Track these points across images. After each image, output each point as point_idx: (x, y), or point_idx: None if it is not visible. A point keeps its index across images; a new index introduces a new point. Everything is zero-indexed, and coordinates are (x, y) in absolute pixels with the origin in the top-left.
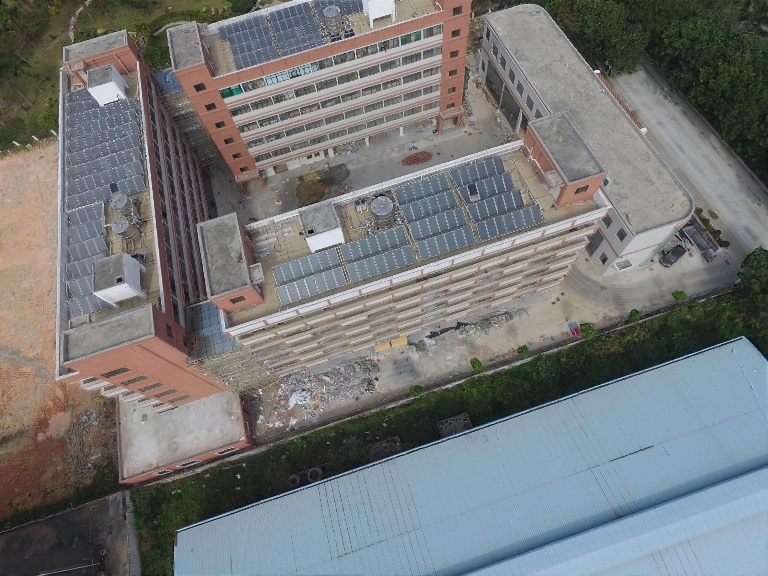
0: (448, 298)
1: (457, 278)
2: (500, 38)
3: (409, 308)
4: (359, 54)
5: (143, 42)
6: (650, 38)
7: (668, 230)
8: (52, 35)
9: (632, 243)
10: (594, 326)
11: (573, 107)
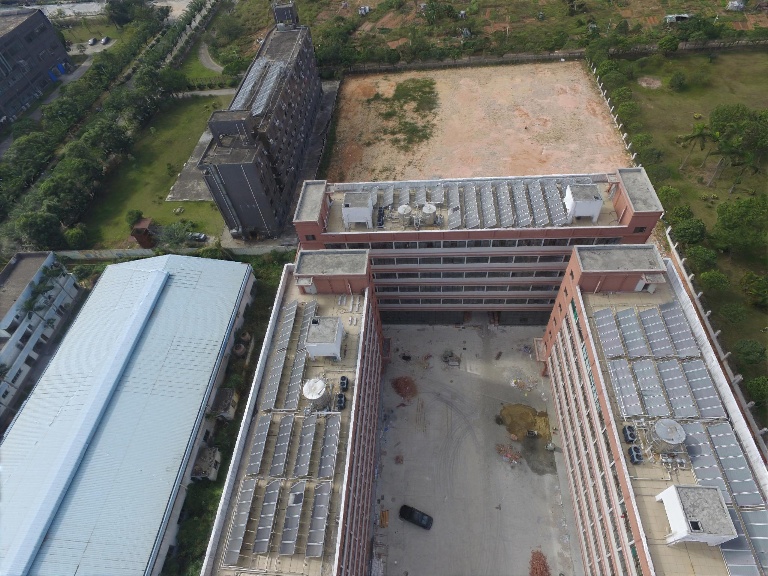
0: None
1: None
2: None
3: None
4: None
5: None
6: None
7: None
8: None
9: None
10: None
11: None
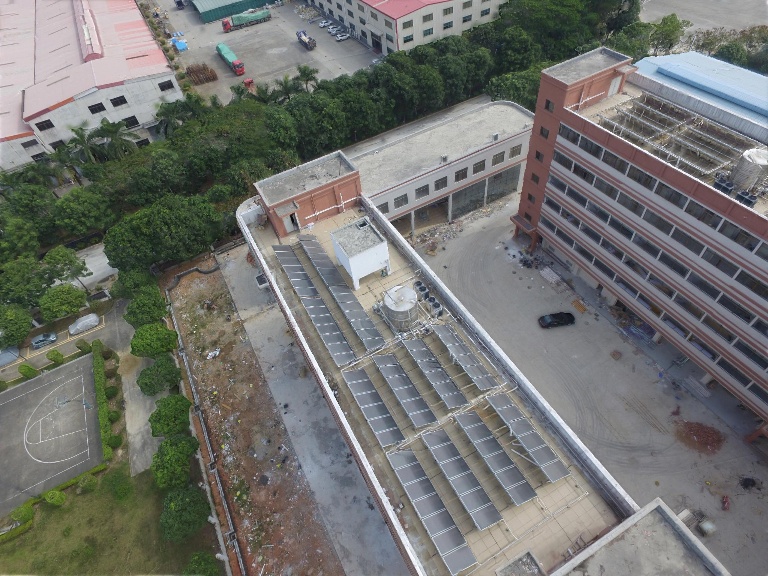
0: None
1: None
2: None
3: None
4: None
5: None
6: None
7: None
8: None
9: None
10: None
11: (402, 167)
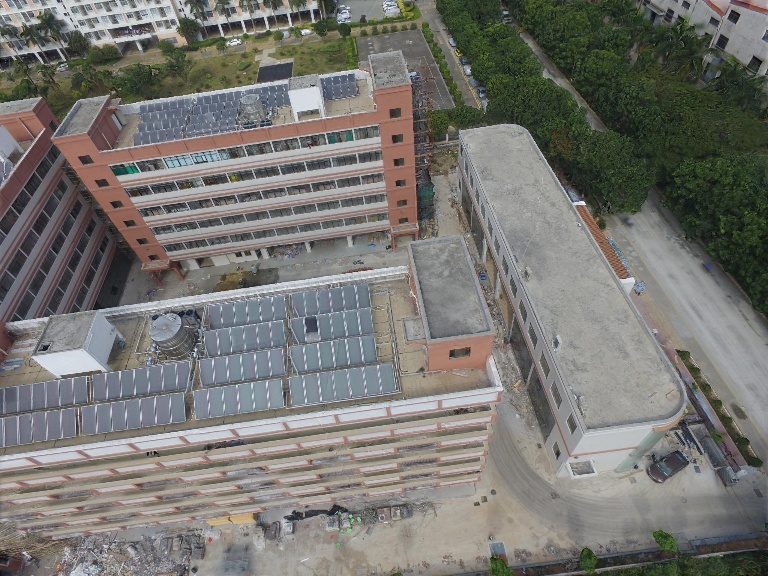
0: (276, 477)
1: (269, 454)
2: (468, 154)
3: (216, 481)
4: (278, 147)
5: None
6: (661, 176)
7: (644, 431)
8: None
9: (585, 441)
10: (529, 558)
11: (536, 239)
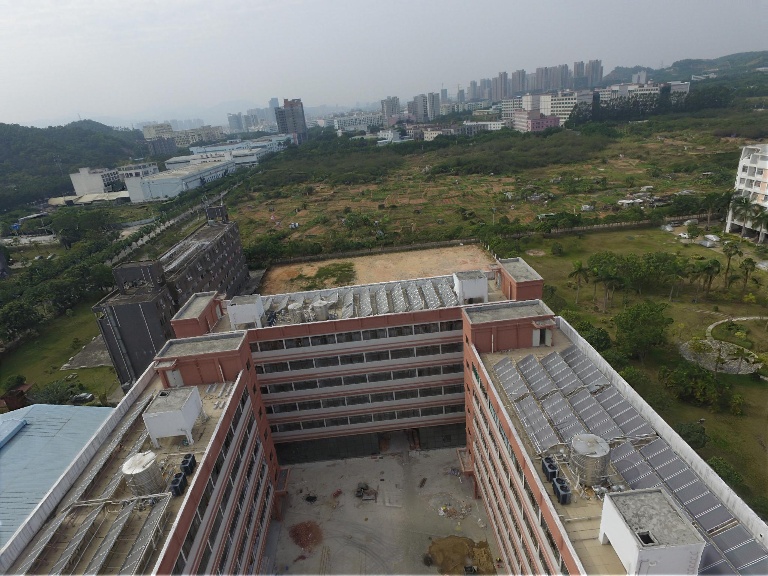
0: None
1: None
2: None
3: None
4: None
5: (743, 370)
6: None
7: None
8: (719, 308)
9: None
10: None
11: None
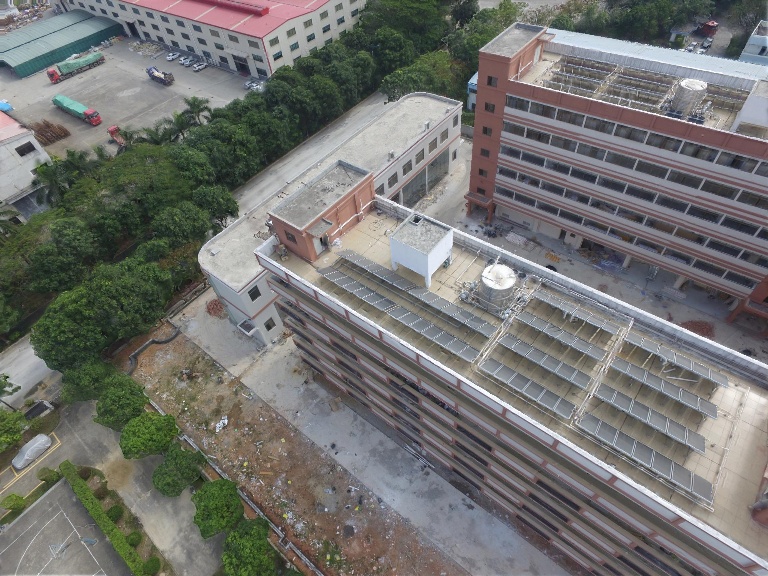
0: None
1: None
2: None
3: None
4: None
5: None
6: None
7: None
8: None
9: None
10: None
11: None
